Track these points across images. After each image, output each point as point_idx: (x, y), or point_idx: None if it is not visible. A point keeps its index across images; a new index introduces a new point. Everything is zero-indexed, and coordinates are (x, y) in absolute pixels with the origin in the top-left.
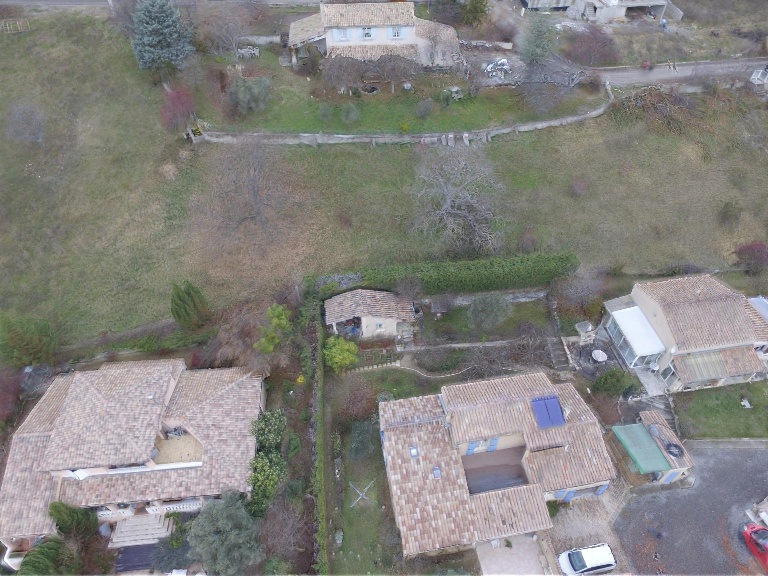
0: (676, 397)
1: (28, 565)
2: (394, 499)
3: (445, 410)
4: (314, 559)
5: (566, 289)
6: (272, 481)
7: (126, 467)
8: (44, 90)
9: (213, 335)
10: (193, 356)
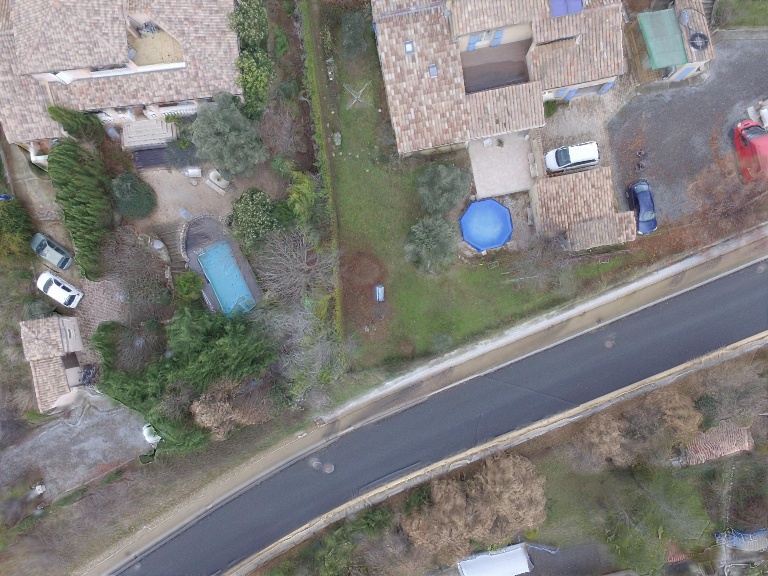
0: None
1: (54, 164)
2: None
3: None
4: (315, 158)
5: None
6: (262, 82)
7: (108, 69)
8: None
9: None
10: None
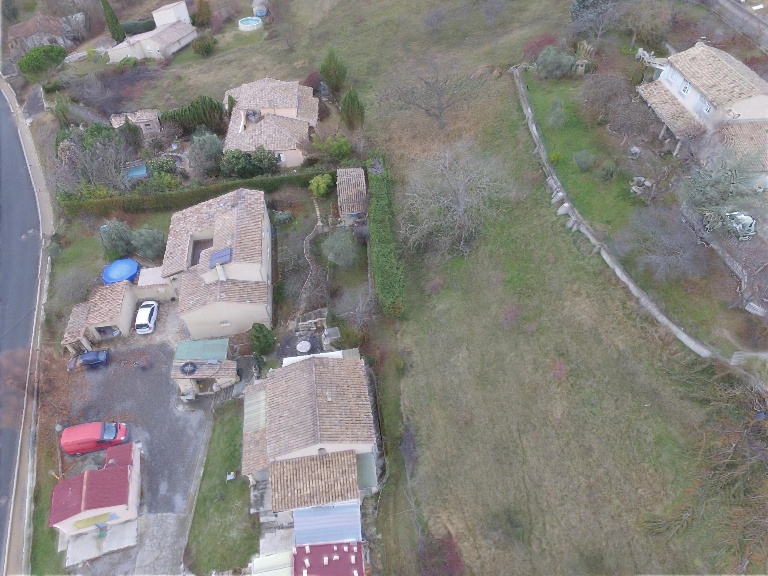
0: None
1: (203, 96)
2: None
3: None
4: None
5: None
6: None
7: None
8: (545, 4)
9: None
10: None
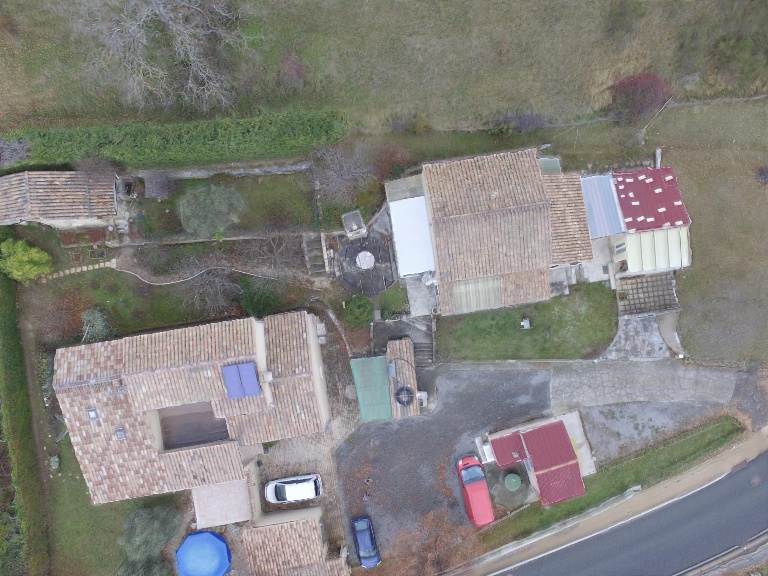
0: (442, 319)
1: None
2: None
3: None
4: None
5: None
6: None
7: None
8: None
9: None
10: None
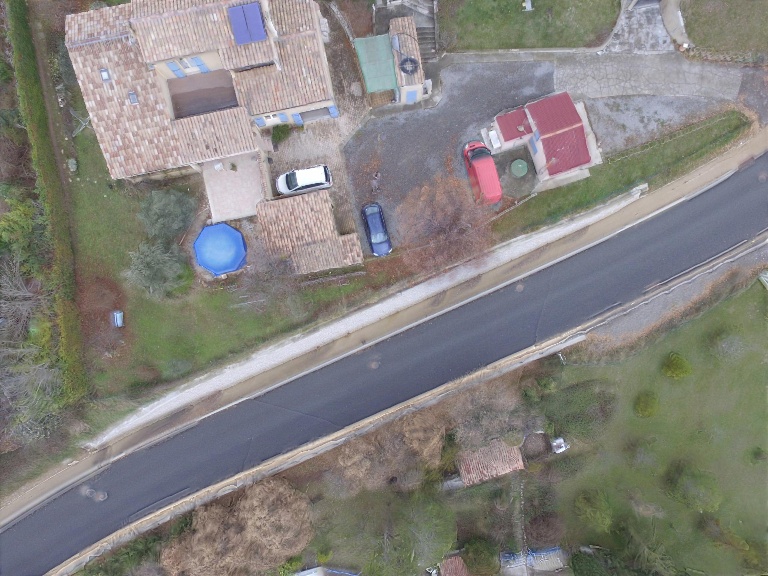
0: None
1: None
2: None
3: None
4: None
5: None
6: None
7: None
8: None
9: None
10: None
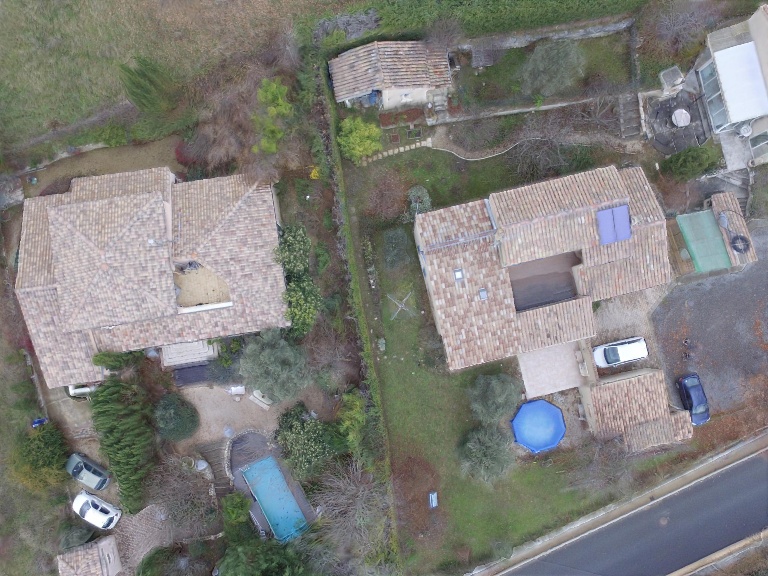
0: (759, 171)
1: (100, 417)
2: (438, 321)
3: (493, 223)
4: (363, 376)
5: (662, 21)
6: (310, 314)
7: None
8: None
9: (192, 123)
10: (176, 154)
